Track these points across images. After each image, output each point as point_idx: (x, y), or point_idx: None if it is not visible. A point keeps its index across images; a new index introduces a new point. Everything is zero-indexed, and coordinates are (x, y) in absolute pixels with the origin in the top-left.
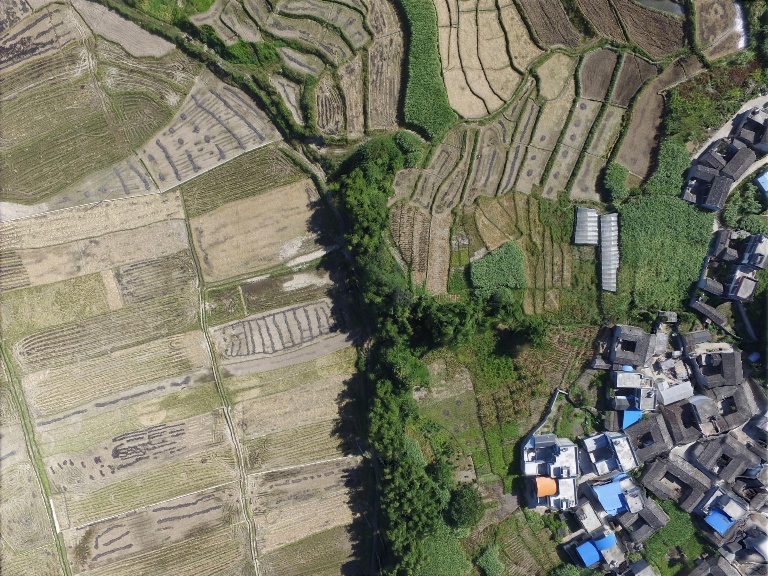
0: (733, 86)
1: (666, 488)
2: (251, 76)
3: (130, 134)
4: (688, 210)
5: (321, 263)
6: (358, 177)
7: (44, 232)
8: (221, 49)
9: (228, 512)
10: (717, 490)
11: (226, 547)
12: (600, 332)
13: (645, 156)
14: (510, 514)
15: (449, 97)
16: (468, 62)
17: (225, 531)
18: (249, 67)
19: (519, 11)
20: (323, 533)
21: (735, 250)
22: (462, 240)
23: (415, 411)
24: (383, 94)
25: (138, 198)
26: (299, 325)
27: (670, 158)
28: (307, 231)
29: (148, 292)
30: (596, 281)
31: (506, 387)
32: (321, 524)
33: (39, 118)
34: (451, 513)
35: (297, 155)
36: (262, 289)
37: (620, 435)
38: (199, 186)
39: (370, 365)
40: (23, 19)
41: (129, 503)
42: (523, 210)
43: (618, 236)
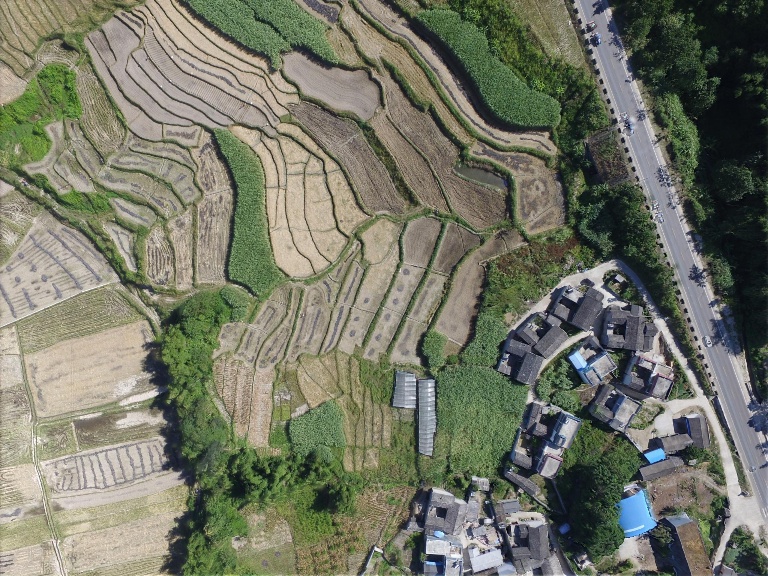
0: (552, 262)
1: None
2: (86, 222)
3: None
4: (502, 382)
5: (154, 403)
6: (175, 336)
7: None
8: (56, 196)
9: None
10: None
11: None
12: (417, 493)
13: (465, 324)
14: None
15: (276, 256)
16: (295, 223)
17: None
18: (84, 213)
19: (345, 177)
20: None
21: (544, 426)
22: (284, 396)
23: (231, 562)
24: (211, 249)
25: None
26: (132, 462)
27: (486, 330)
28: (142, 371)
29: None
30: (414, 443)
31: (325, 541)
32: None
33: None
34: None
35: (133, 298)
36: (95, 426)
37: None
38: (35, 323)
39: (198, 507)
40: None
41: None
42: (345, 370)
43: (435, 402)
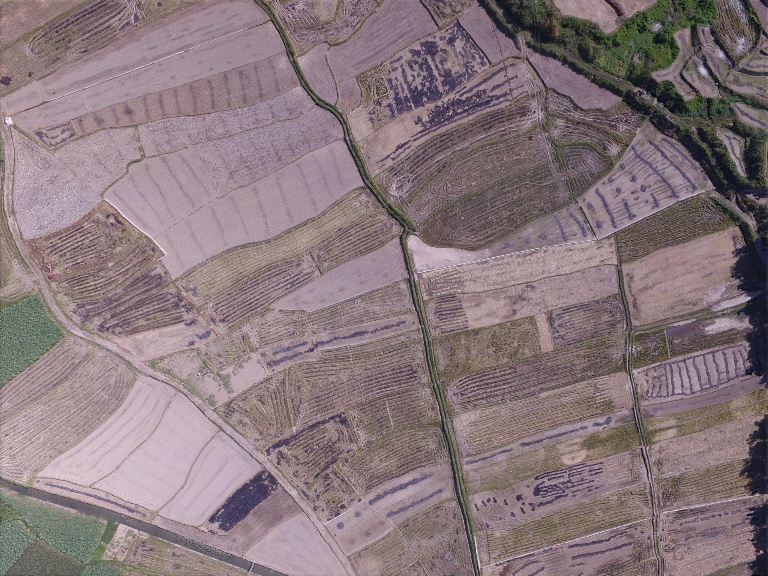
0: None
1: None
2: (697, 129)
3: (572, 183)
4: None
5: (744, 308)
6: None
7: (485, 277)
8: (675, 103)
9: (639, 549)
10: None
11: None
12: None
13: None
14: None
15: None
16: None
17: (635, 567)
18: (696, 120)
19: None
20: (727, 569)
21: None
22: None
23: None
24: None
25: (574, 244)
26: (717, 367)
27: None
28: (731, 277)
29: (578, 335)
30: None
31: None
32: (726, 561)
33: (488, 167)
34: None
35: (729, 204)
36: (685, 333)
37: None
38: (633, 233)
39: None
40: (481, 73)
41: (547, 540)
42: None
43: None
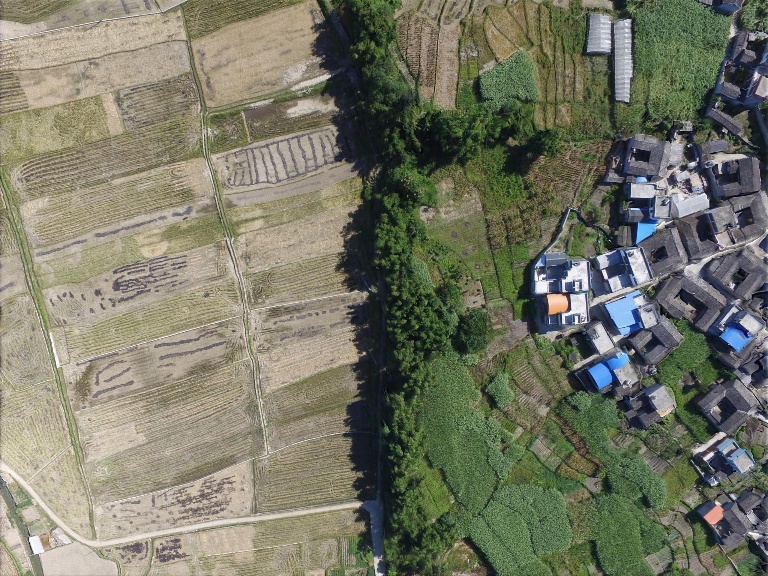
0: None
1: (681, 306)
2: None
3: None
4: (704, 12)
5: (326, 88)
6: None
7: (42, 52)
8: None
9: (231, 349)
10: (733, 306)
11: (229, 385)
12: (613, 147)
13: None
14: (520, 341)
15: None
16: None
17: (228, 368)
18: None
19: None
20: (328, 372)
21: (753, 51)
22: (471, 52)
23: (423, 230)
24: None
25: (138, 18)
26: (303, 154)
27: None
28: (312, 55)
29: (149, 117)
30: (609, 93)
31: (516, 207)
32: (326, 362)
33: None
34: (460, 336)
35: None
36: (266, 115)
37: (634, 248)
38: (201, 6)
39: (376, 193)
40: None
41: (130, 338)
42: (534, 20)
43: (632, 44)
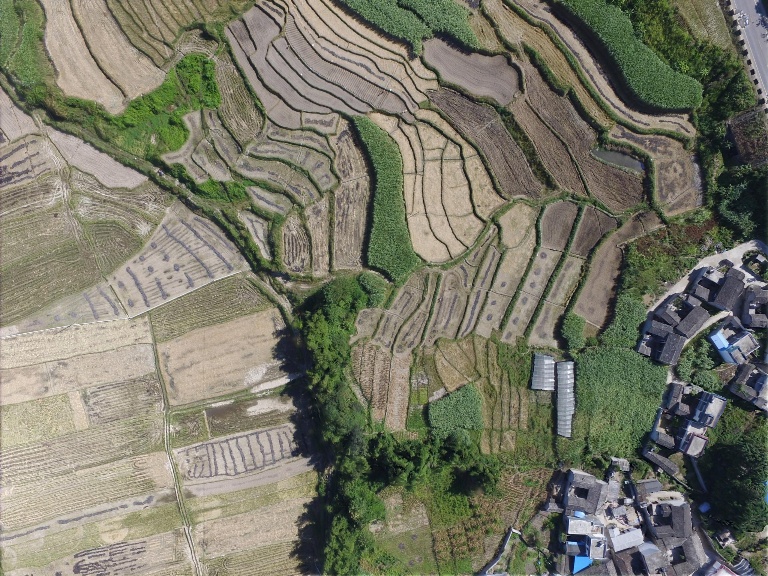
0: (690, 243)
1: None
2: (221, 210)
3: (101, 261)
4: (642, 363)
5: (285, 390)
6: (319, 322)
7: (13, 353)
8: (192, 185)
9: None
10: None
11: None
12: (555, 474)
13: (603, 306)
14: None
15: (413, 241)
16: (432, 208)
17: None
18: (219, 202)
19: (483, 162)
20: None
21: (687, 406)
22: (422, 380)
23: (370, 545)
24: (348, 236)
25: (107, 323)
26: (262, 449)
27: (626, 311)
28: (272, 358)
29: (114, 413)
30: (552, 425)
31: (461, 523)
32: None
33: (12, 244)
34: None
35: (264, 286)
36: (226, 413)
37: None
38: (167, 312)
39: (330, 492)
40: None
41: None
42: (482, 353)
43: (574, 384)
